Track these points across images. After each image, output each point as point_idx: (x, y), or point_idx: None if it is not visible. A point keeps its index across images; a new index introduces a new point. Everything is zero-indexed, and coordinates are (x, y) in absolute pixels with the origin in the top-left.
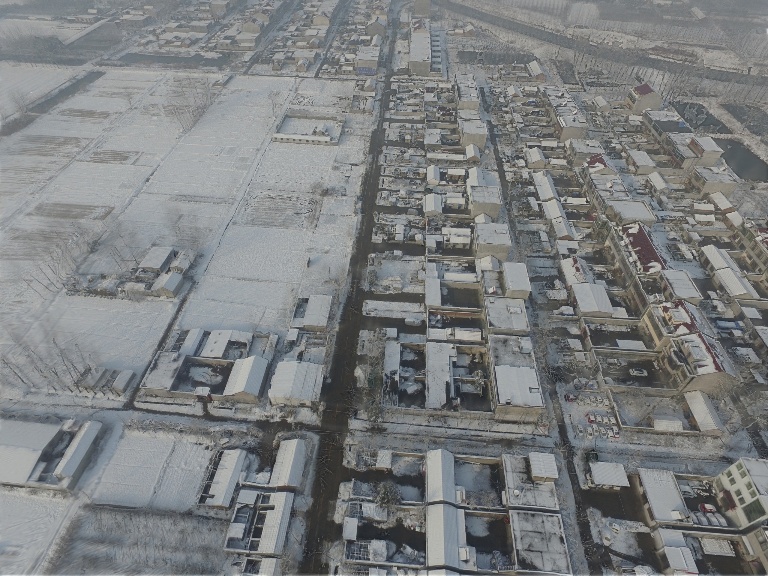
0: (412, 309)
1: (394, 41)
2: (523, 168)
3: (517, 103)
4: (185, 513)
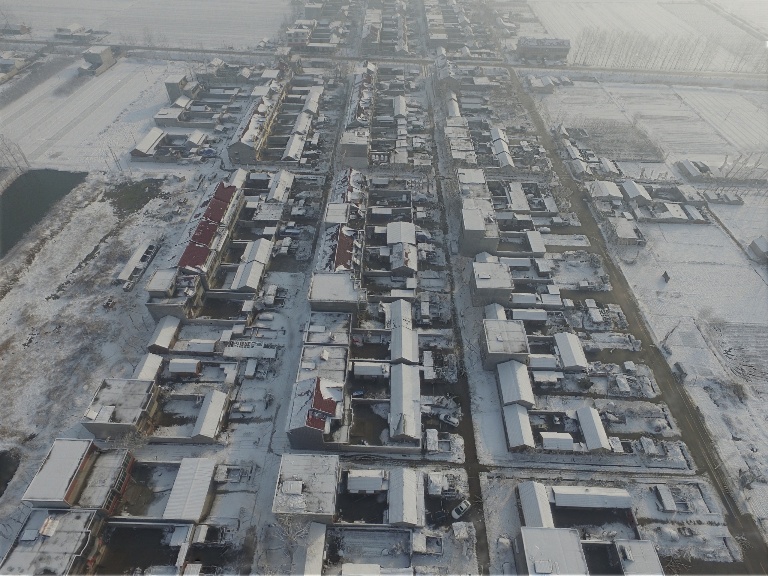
0: (548, 240)
1: None
2: None
3: None
4: (618, 161)
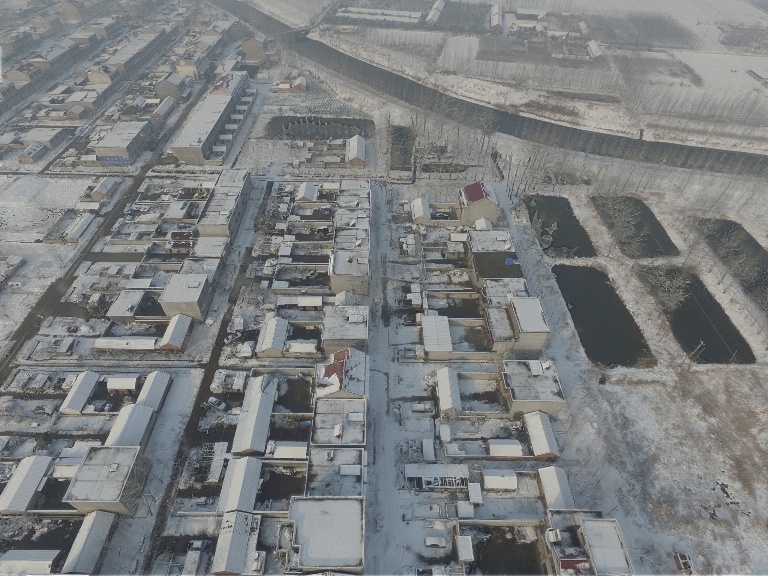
0: None
1: (194, 103)
2: (248, 359)
3: (307, 210)
4: None
